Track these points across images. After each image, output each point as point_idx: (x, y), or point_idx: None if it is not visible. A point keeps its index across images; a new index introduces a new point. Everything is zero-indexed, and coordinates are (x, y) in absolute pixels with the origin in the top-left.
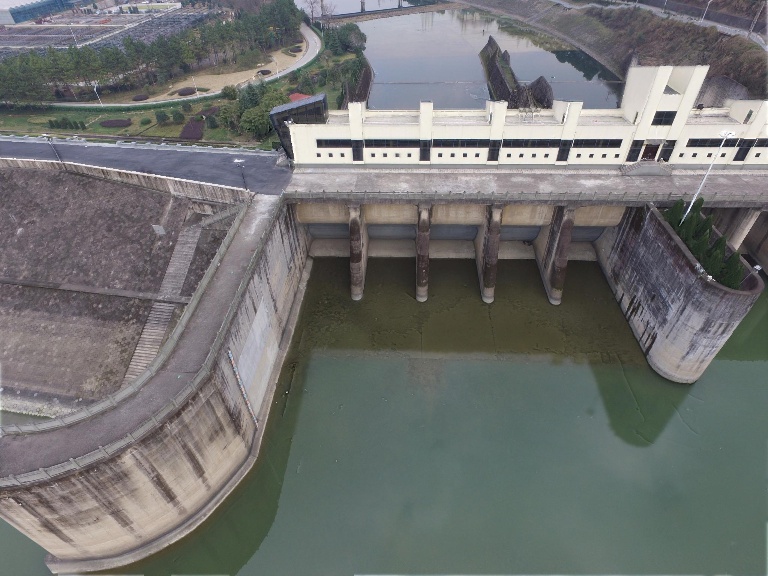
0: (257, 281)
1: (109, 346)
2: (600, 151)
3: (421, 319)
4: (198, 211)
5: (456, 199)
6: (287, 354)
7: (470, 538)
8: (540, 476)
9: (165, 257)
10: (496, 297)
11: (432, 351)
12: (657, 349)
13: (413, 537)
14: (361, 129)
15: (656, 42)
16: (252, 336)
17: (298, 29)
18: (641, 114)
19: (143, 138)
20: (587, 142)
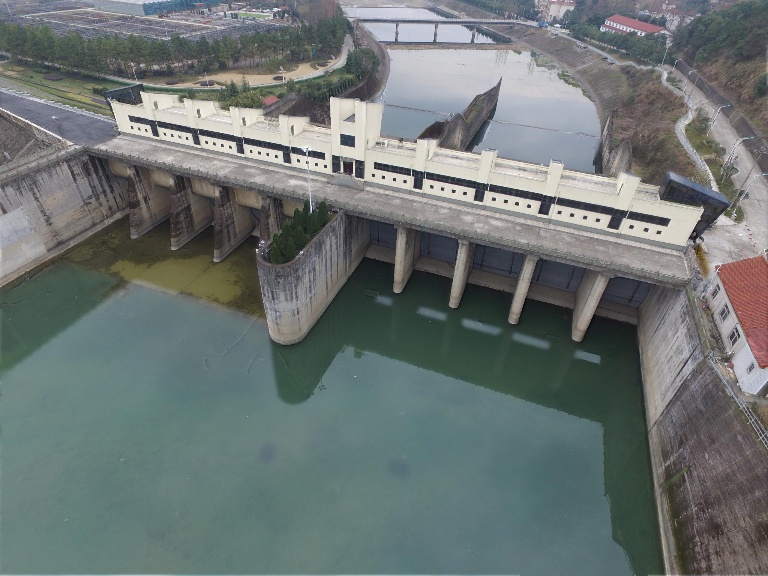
0: (12, 193)
1: None
2: (312, 160)
3: (159, 260)
4: None
5: (186, 173)
6: (53, 257)
7: (36, 380)
8: (114, 363)
9: None
10: (226, 260)
11: (141, 279)
12: None
13: (7, 370)
14: (152, 112)
15: (641, 105)
16: None
17: (335, 47)
18: None
19: None
20: (301, 151)
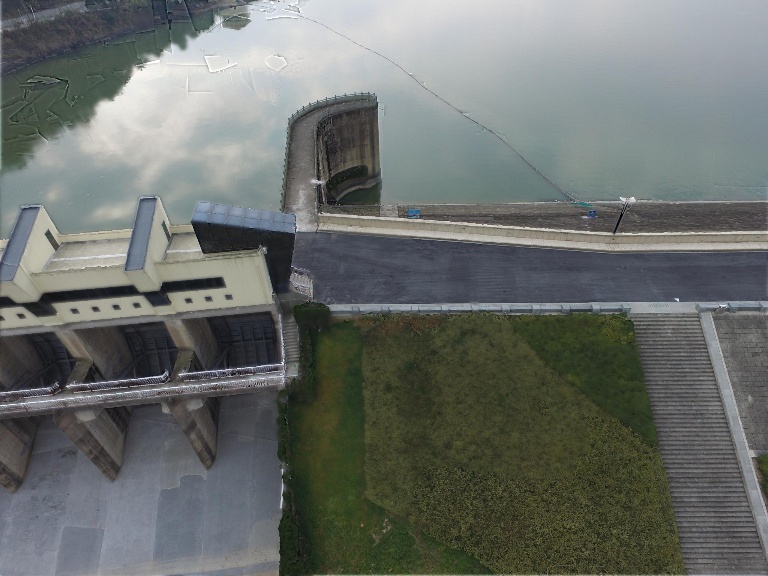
0: None
1: None
2: None
3: None
4: None
5: None
6: None
7: None
8: None
9: None
10: None
11: None
12: None
13: (212, 196)
14: None
15: None
16: None
17: None
18: None
19: None
20: None
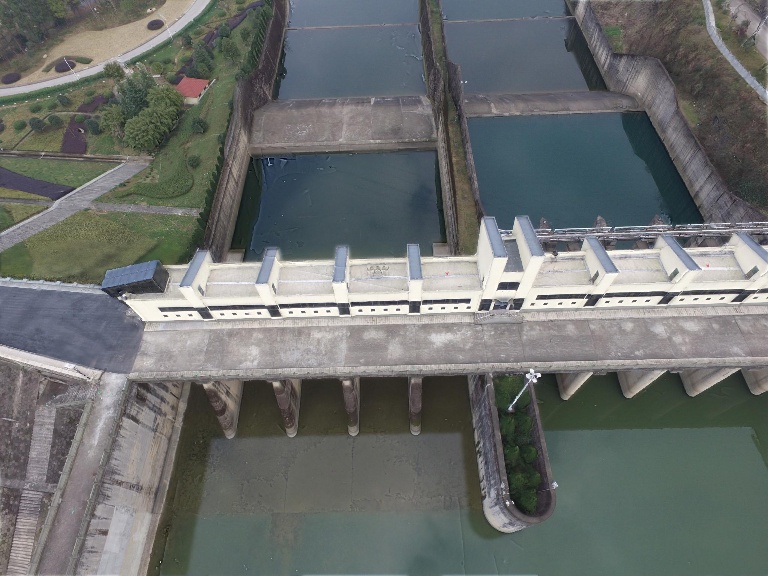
0: (102, 507)
1: None
2: (451, 305)
3: (288, 461)
4: (52, 380)
5: (302, 377)
6: (161, 516)
7: None
8: None
9: (25, 440)
10: (362, 426)
11: (294, 503)
12: (486, 507)
13: None
14: (200, 301)
15: None
16: (106, 556)
17: None
18: (485, 283)
19: (20, 153)
20: (436, 301)
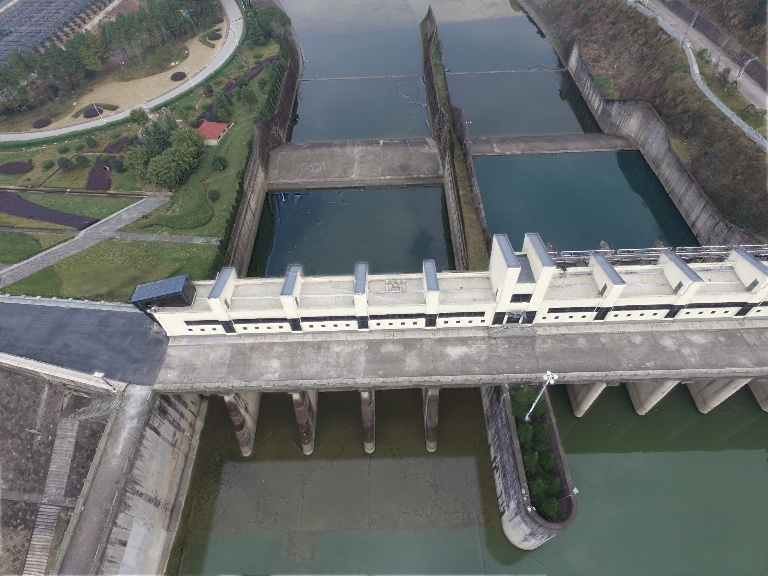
0: (123, 517)
1: (1, 555)
2: (466, 319)
3: (305, 478)
4: (76, 394)
5: (322, 388)
6: (176, 534)
7: None
8: None
9: (46, 454)
10: (378, 444)
11: (311, 521)
12: (505, 522)
13: None
14: (226, 314)
15: (600, 24)
16: (124, 569)
17: (216, 5)
18: (499, 295)
19: (47, 189)
20: (452, 314)
